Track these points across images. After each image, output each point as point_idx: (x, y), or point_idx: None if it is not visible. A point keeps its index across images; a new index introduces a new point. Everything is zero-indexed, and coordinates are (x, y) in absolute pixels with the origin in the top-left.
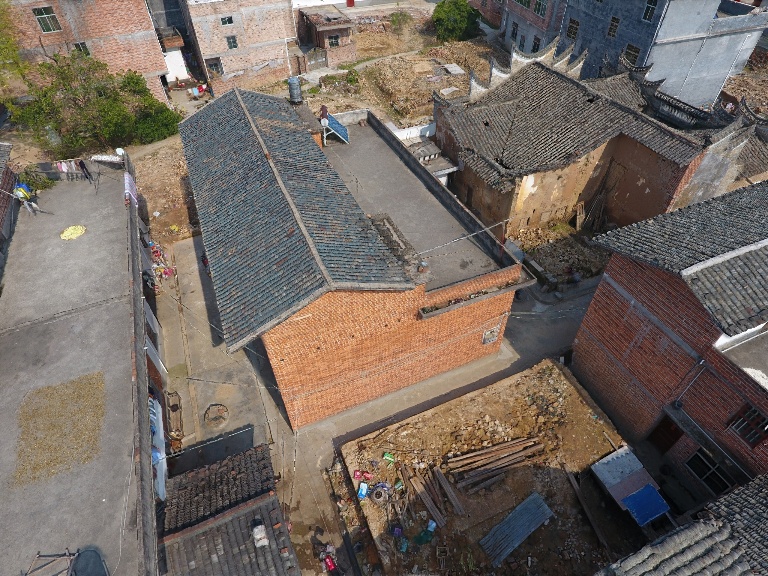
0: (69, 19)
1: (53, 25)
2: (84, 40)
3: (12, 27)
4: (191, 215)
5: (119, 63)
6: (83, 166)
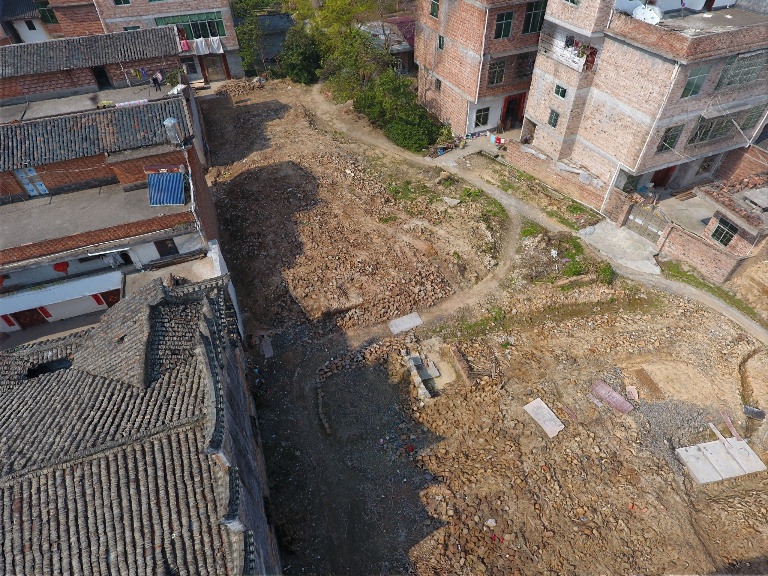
0: (443, 12)
1: (436, 12)
2: (444, 35)
3: (420, 1)
4: (235, 177)
5: (453, 69)
6: (156, 82)
